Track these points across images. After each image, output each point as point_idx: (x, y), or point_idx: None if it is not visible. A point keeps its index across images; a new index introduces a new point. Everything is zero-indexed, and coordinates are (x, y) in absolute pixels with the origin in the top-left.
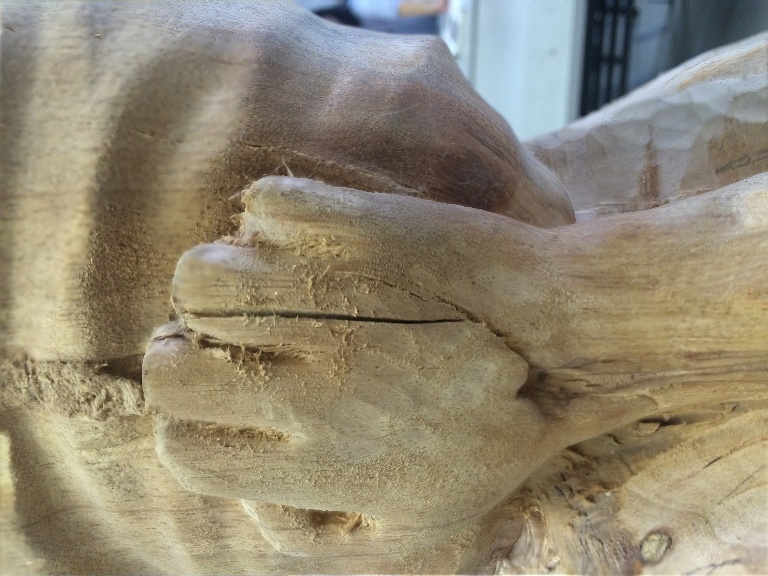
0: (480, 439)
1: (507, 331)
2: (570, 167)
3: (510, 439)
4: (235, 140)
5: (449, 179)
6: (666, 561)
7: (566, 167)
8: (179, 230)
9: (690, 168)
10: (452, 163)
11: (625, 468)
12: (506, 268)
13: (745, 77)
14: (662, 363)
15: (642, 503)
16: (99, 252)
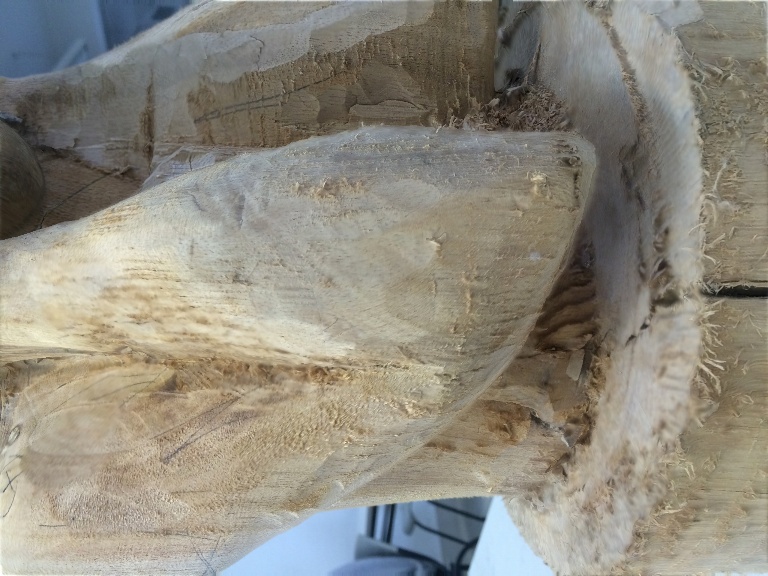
0: None
1: None
2: (88, 103)
3: None
4: None
5: None
6: (12, 445)
7: (85, 103)
8: None
9: (175, 116)
10: None
11: (27, 380)
12: None
13: (223, 33)
14: None
15: (25, 405)
16: None
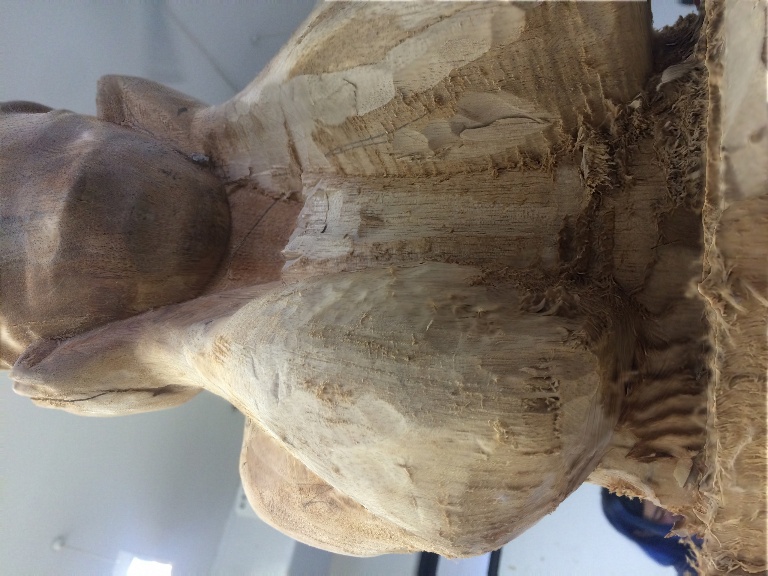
0: None
1: None
2: (249, 137)
3: None
4: (7, 325)
5: (98, 305)
6: None
7: (246, 137)
8: (20, 348)
9: (310, 151)
10: (95, 298)
11: None
12: (115, 371)
13: (321, 77)
14: None
15: None
16: (5, 358)
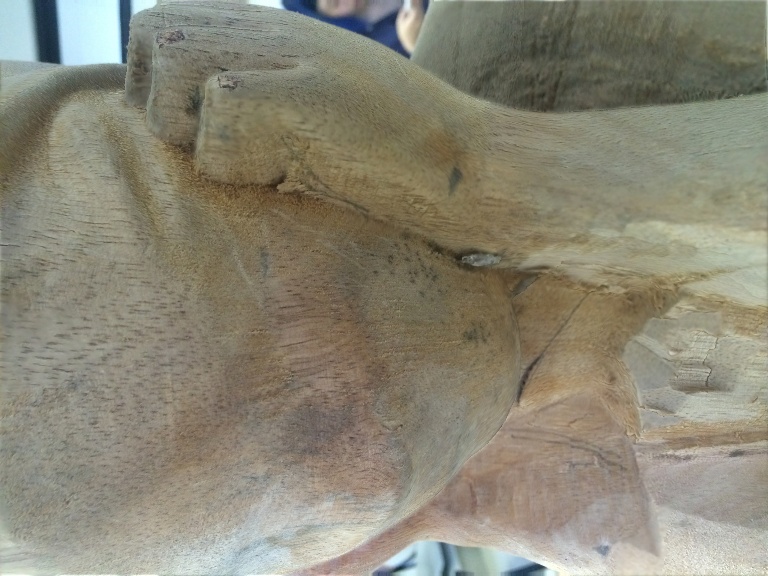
0: None
1: None
2: None
3: None
4: None
5: None
6: None
7: None
8: None
9: None
10: None
11: None
12: None
13: None
14: None
15: None
16: None
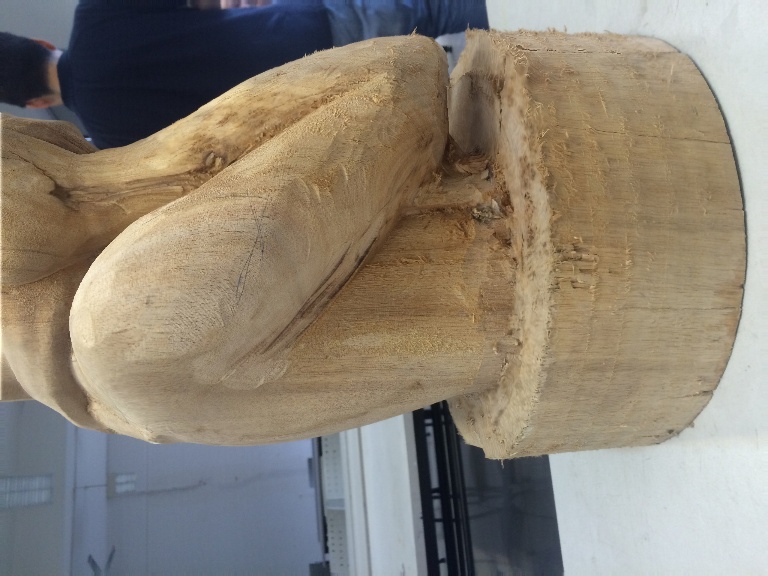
0: (32, 206)
1: (44, 169)
2: None
3: (48, 211)
4: None
5: None
6: None
7: None
8: None
9: None
10: None
11: None
12: (48, 153)
13: None
14: (117, 187)
15: None
16: None
